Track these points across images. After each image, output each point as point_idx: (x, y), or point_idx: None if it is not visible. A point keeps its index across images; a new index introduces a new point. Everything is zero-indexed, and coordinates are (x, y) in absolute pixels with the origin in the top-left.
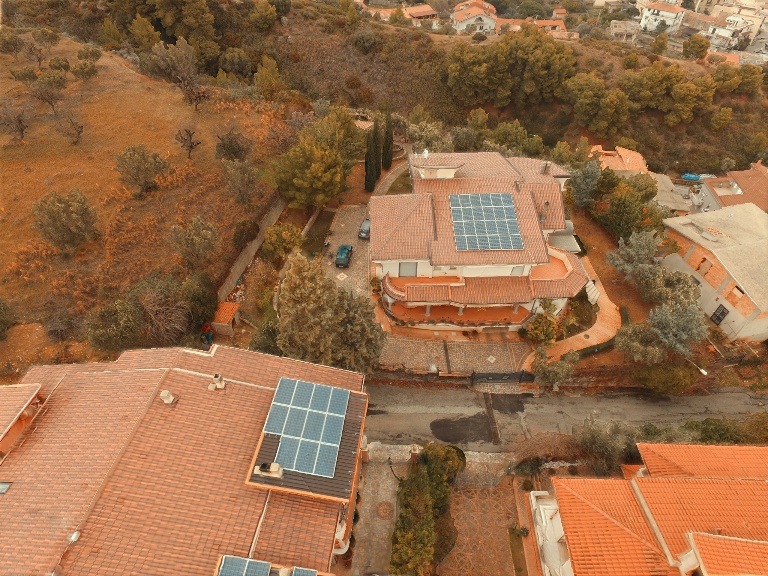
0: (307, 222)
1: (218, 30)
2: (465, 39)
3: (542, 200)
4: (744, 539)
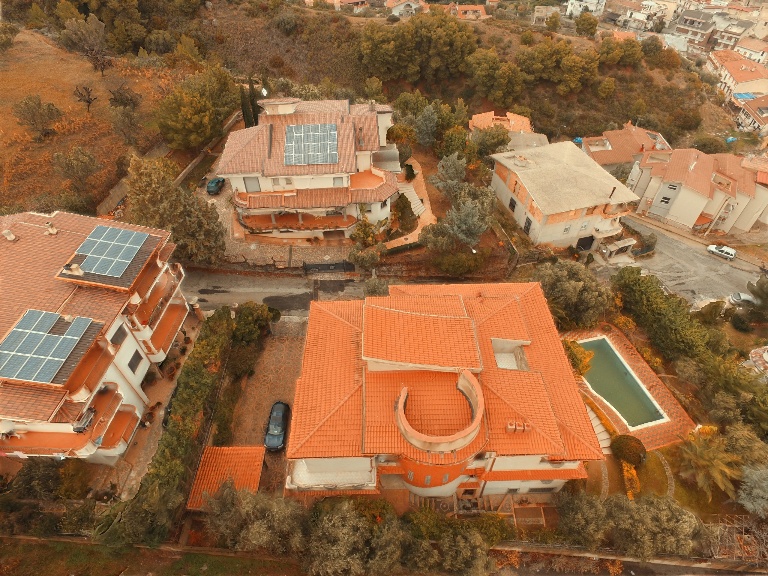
0: (190, 163)
1: (145, 14)
2: (380, 21)
3: (362, 128)
4: (406, 312)
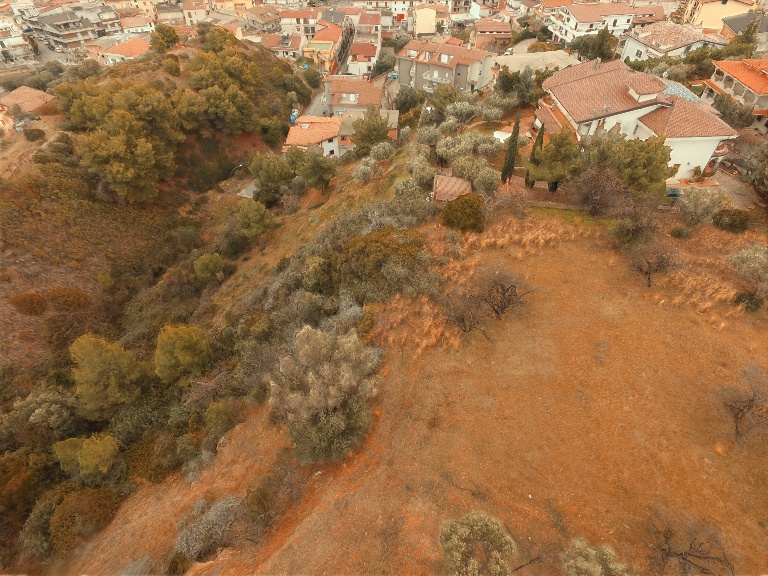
0: None
1: None
2: (25, 148)
3: None
4: None
